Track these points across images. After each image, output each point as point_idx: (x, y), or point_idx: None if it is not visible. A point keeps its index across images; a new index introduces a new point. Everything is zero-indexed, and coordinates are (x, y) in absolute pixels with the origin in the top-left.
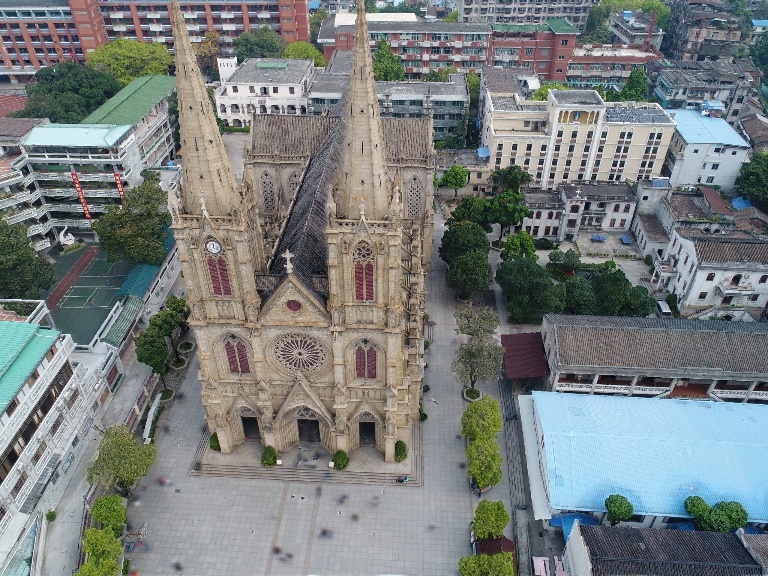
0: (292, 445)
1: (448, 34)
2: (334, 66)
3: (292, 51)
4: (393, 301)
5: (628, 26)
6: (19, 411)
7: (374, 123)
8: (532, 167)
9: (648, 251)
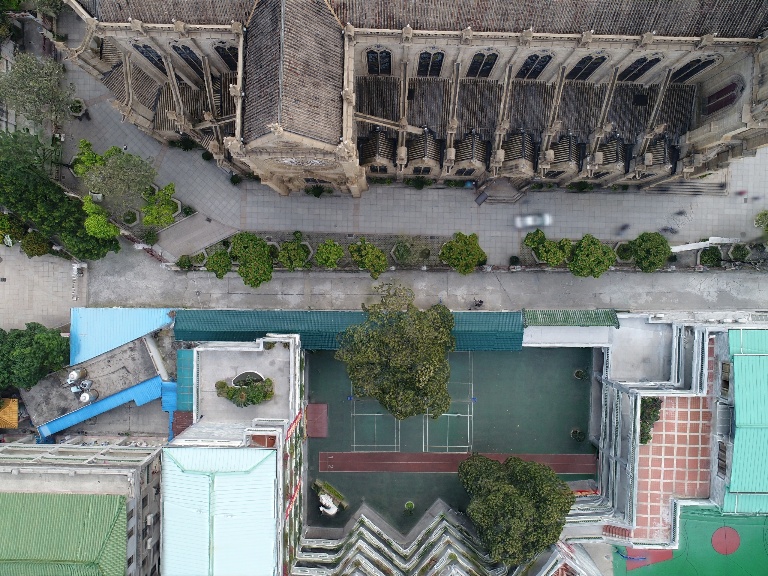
0: None
1: None
2: None
3: None
4: None
5: None
6: None
7: None
8: None
9: None
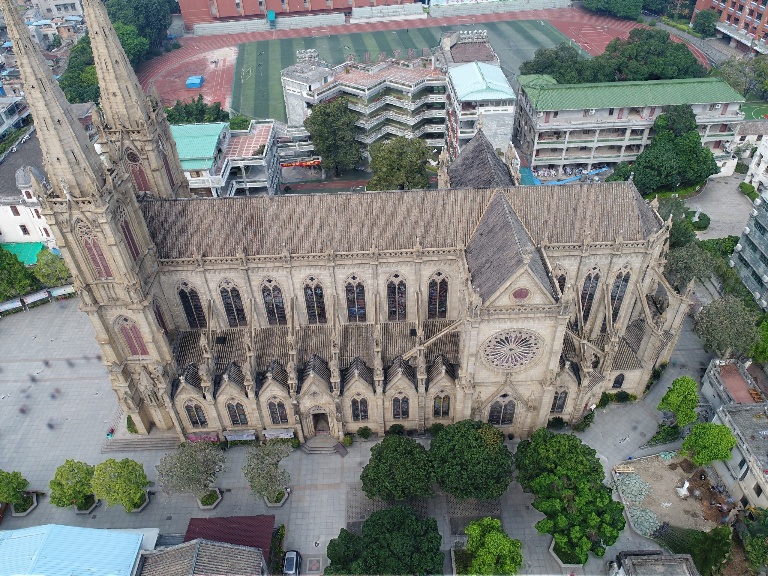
0: None
1: None
2: None
3: None
4: None
5: None
6: None
7: None
8: None
9: None
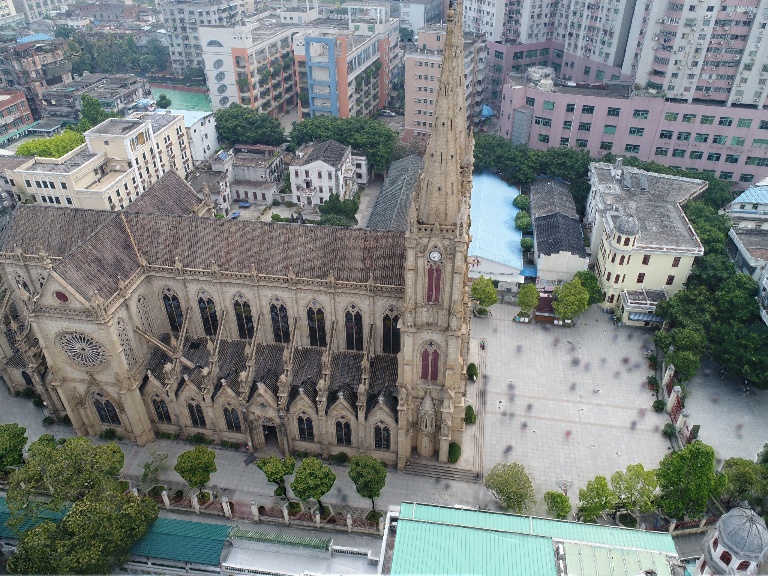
0: None
1: None
2: None
3: None
4: None
5: None
6: None
7: None
8: None
9: (271, 197)
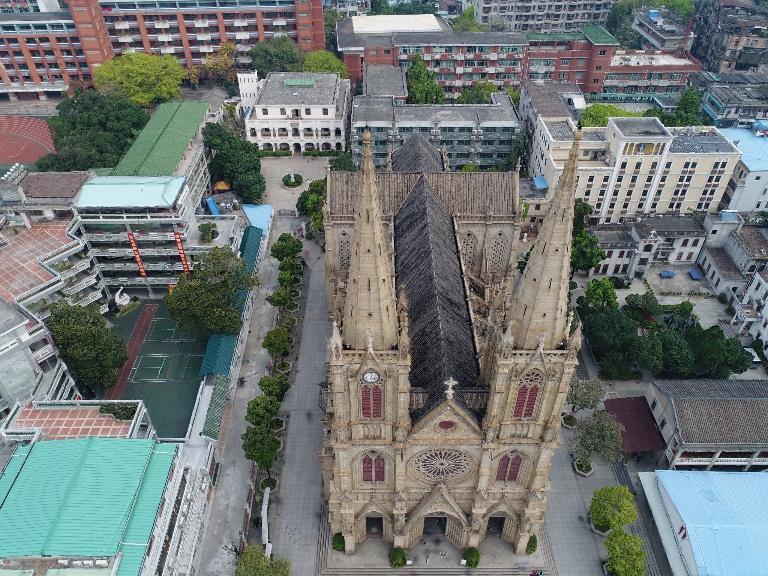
0: (417, 540)
1: (483, 46)
2: (370, 86)
3: (313, 62)
4: (555, 419)
5: (657, 28)
6: (155, 546)
7: (566, 259)
8: (592, 198)
9: (722, 289)
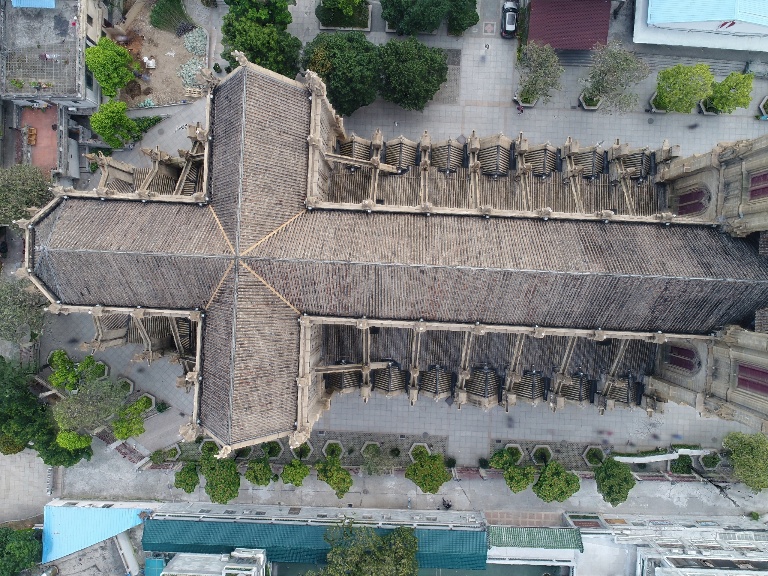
0: None
1: None
2: None
3: None
4: None
5: None
6: None
7: None
8: None
9: None
